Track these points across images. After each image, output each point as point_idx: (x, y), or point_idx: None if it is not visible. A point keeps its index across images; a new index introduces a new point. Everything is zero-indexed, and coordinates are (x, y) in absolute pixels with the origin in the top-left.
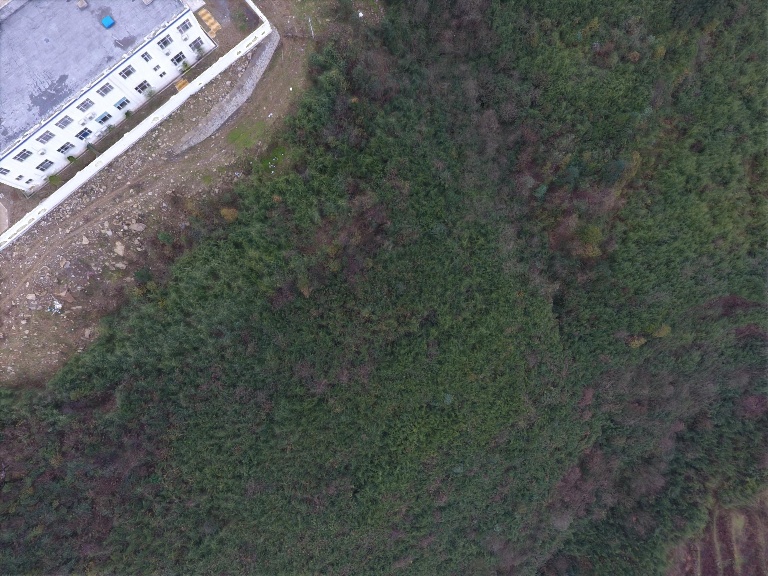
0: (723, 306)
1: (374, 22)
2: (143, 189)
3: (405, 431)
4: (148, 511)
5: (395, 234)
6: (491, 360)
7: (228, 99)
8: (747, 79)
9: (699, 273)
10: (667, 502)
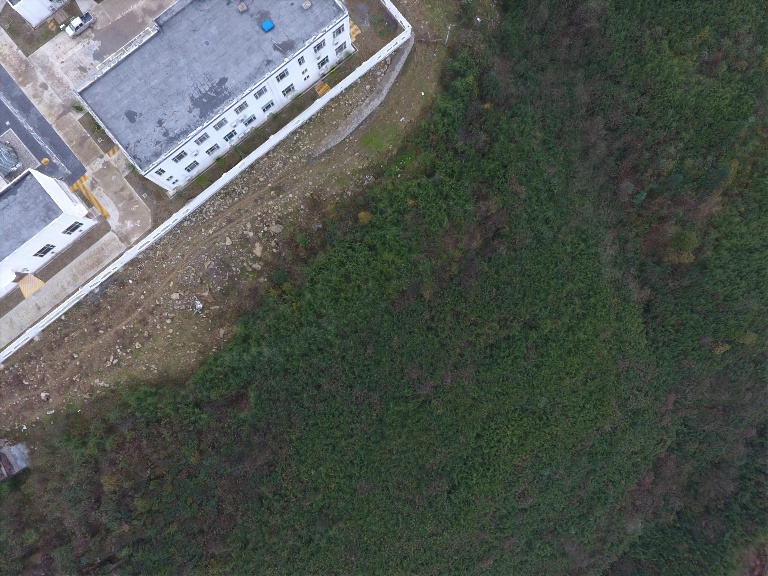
0: None
1: (490, 28)
2: (283, 191)
3: (499, 433)
4: (266, 509)
5: (509, 238)
6: (585, 364)
7: (367, 103)
8: None
9: None
10: (737, 507)
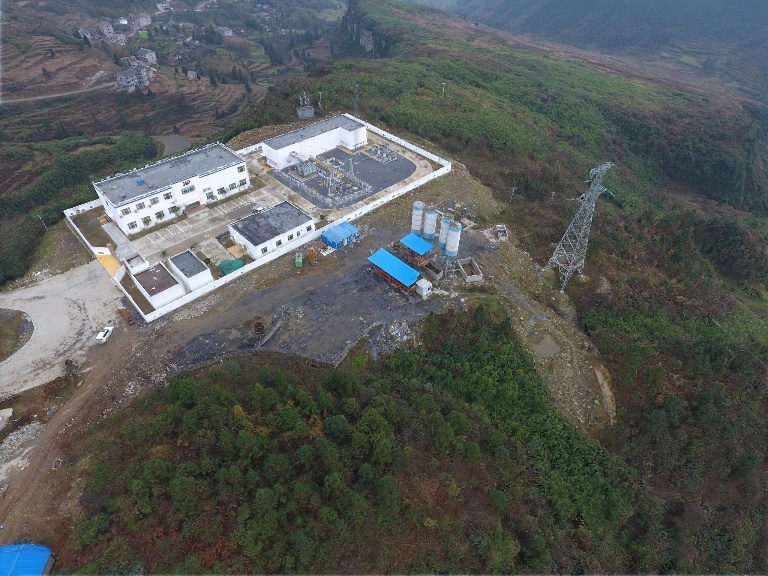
0: None
1: None
2: None
3: None
4: None
5: None
6: None
7: None
8: None
9: None
10: (8, 209)
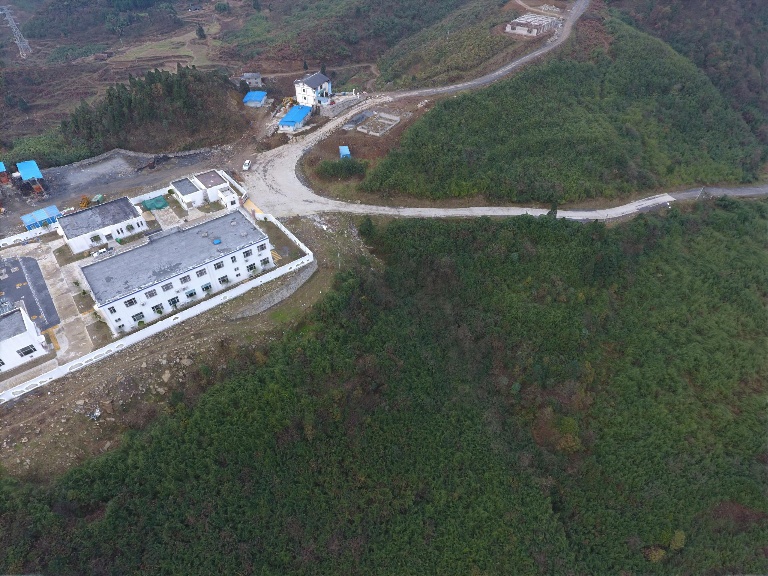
0: (735, 521)
1: None
2: (201, 337)
3: None
4: None
5: (391, 399)
6: (494, 552)
7: (277, 290)
8: (655, 320)
9: (687, 471)
10: None
